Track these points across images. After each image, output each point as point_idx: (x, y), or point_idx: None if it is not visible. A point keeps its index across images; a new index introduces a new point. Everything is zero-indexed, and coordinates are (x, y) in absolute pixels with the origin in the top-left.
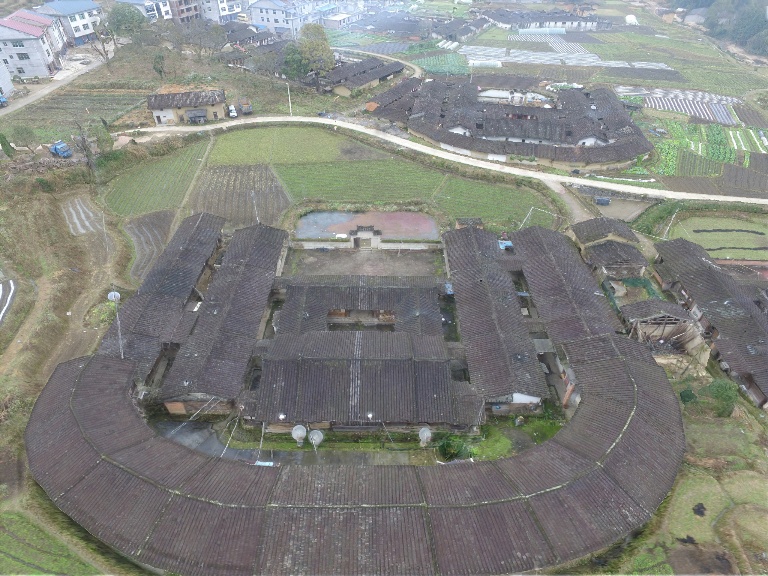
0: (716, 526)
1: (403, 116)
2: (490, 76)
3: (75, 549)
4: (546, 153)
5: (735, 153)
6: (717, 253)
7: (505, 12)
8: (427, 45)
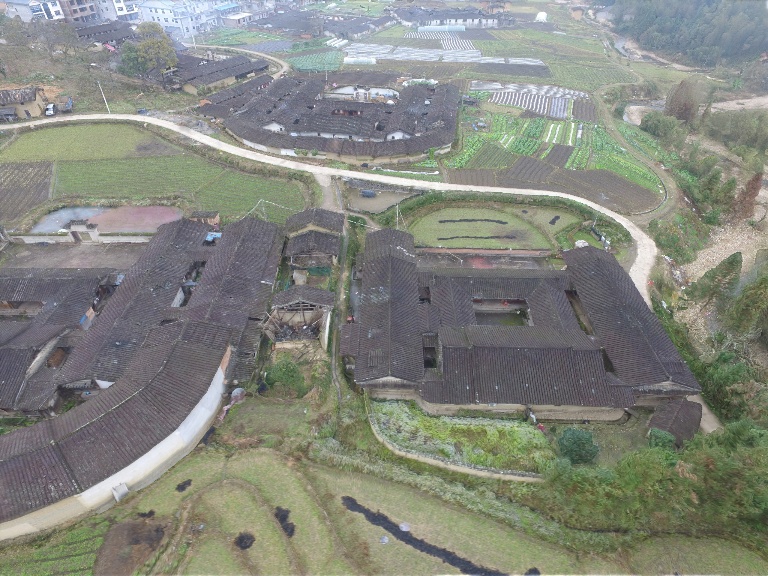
0: None
1: (226, 113)
2: (355, 73)
3: None
4: (333, 147)
5: (540, 145)
6: (446, 242)
7: (416, 10)
8: (312, 43)
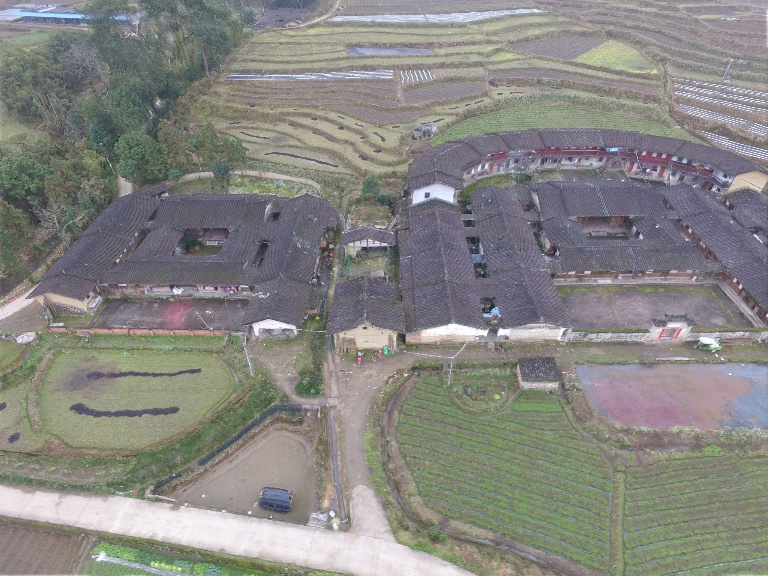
0: (407, 160)
1: None
2: None
3: None
4: None
5: None
6: (192, 364)
7: None
8: None
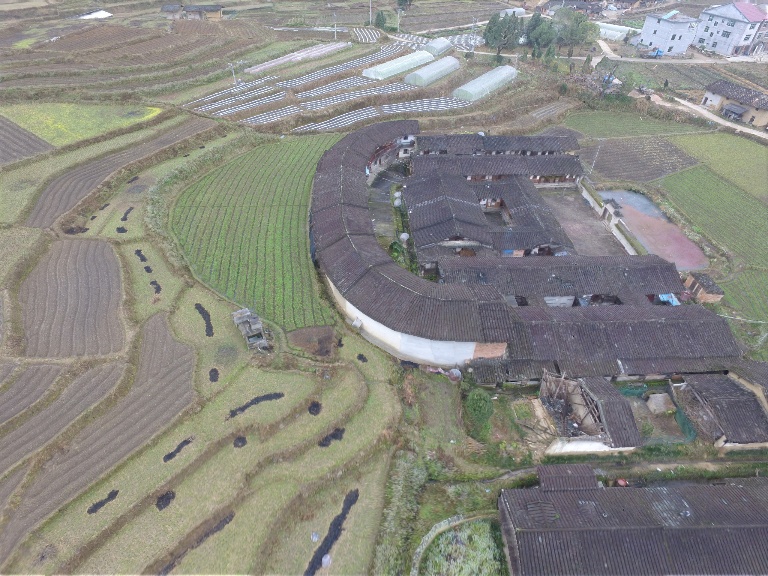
0: None
1: None
2: None
3: None
4: None
5: None
6: None
7: None
8: None
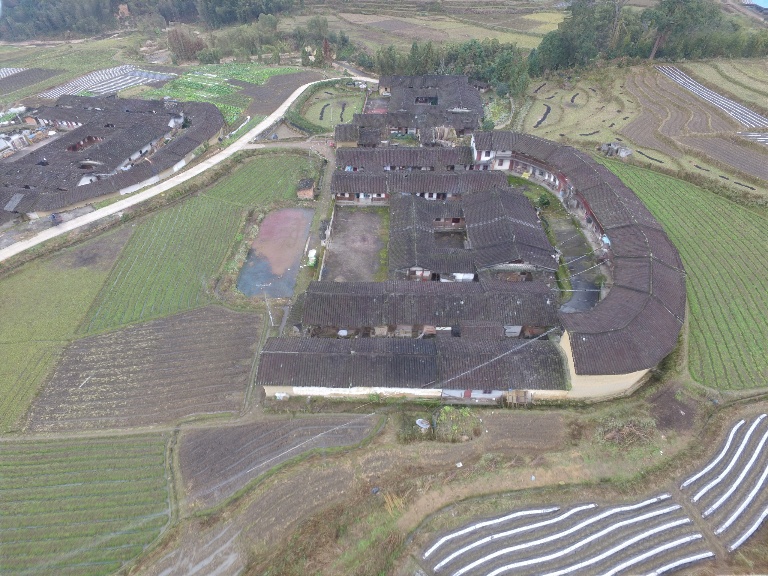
0: None
1: (3, 213)
2: None
3: (687, 329)
4: (200, 137)
5: None
6: (346, 120)
7: None
8: None
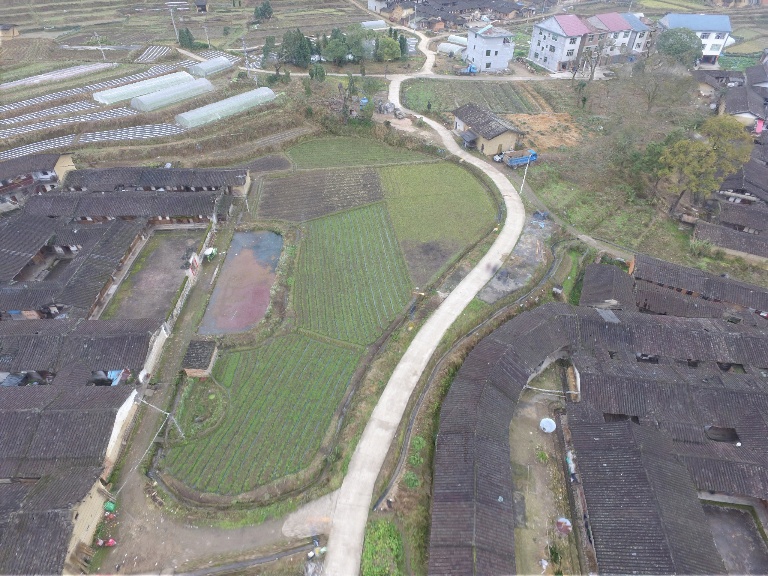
0: None
1: (595, 298)
2: None
3: None
4: (446, 520)
5: None
6: None
7: None
8: None
